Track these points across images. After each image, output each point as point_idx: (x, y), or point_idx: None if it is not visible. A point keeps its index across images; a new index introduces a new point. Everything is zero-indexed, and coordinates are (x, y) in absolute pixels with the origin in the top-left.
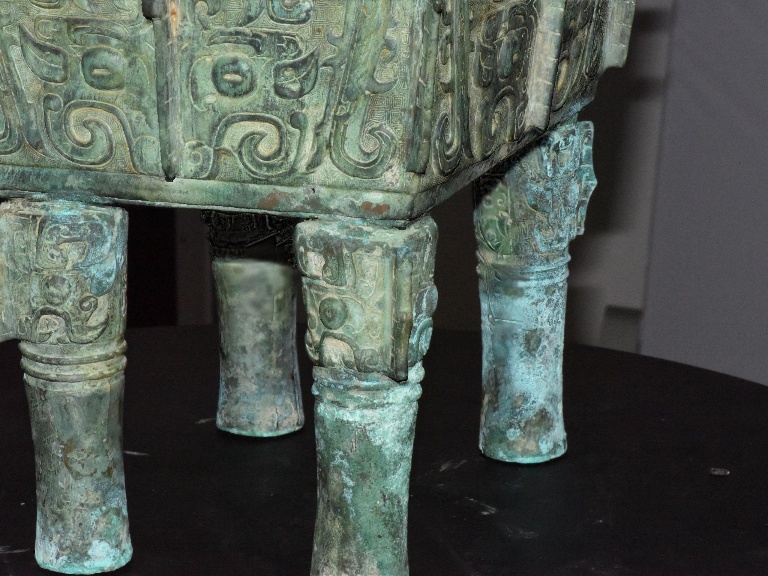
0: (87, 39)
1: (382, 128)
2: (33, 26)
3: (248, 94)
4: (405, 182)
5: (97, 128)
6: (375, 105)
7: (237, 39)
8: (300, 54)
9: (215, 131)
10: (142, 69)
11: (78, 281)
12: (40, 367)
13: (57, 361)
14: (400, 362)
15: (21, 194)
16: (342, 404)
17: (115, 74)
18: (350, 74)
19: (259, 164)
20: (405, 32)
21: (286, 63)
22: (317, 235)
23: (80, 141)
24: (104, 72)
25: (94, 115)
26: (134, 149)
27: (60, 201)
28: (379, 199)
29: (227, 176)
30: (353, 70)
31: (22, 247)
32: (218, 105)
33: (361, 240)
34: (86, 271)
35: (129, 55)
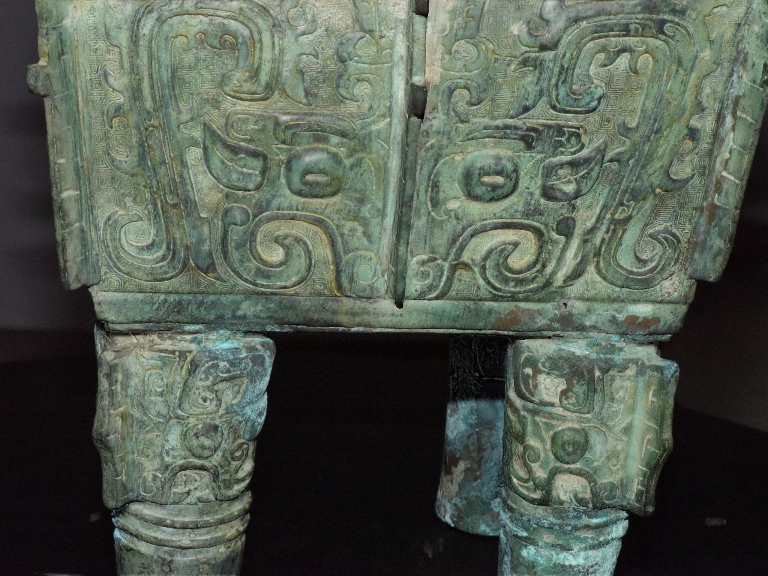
0: (299, 137)
1: (667, 231)
2: (224, 123)
3: (506, 198)
4: (684, 291)
5: (294, 244)
6: (662, 204)
7: (505, 134)
8: (582, 149)
9: (455, 243)
10: (368, 172)
11: (231, 426)
12: (166, 532)
13: (195, 525)
14: (649, 495)
15: (168, 326)
16: (567, 547)
17: (334, 180)
18: (640, 170)
19: (506, 279)
20: (711, 119)
21: (562, 160)
22: (558, 355)
23: (268, 261)
24: (318, 177)
25: (290, 228)
26: (343, 268)
27: (221, 332)
28: (648, 311)
29: (459, 294)
30: (645, 166)
31: (158, 390)
32: (463, 211)
33: (613, 358)
34: (241, 413)
35: (352, 155)
